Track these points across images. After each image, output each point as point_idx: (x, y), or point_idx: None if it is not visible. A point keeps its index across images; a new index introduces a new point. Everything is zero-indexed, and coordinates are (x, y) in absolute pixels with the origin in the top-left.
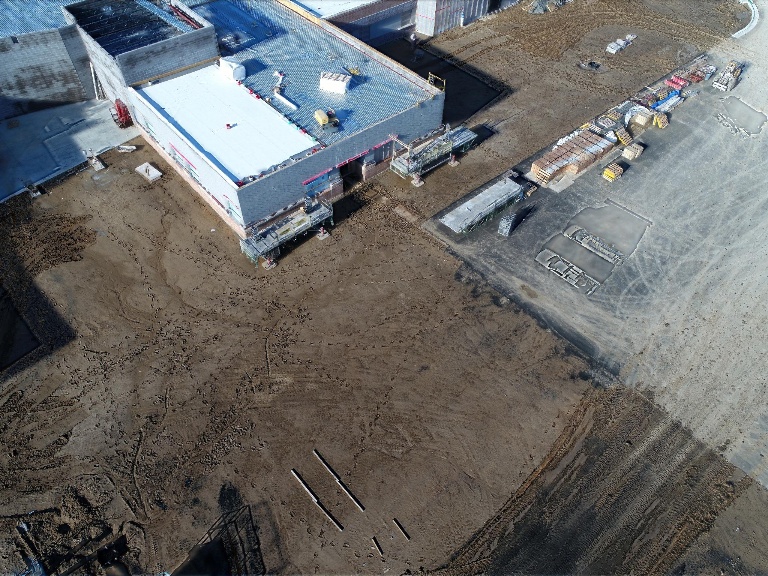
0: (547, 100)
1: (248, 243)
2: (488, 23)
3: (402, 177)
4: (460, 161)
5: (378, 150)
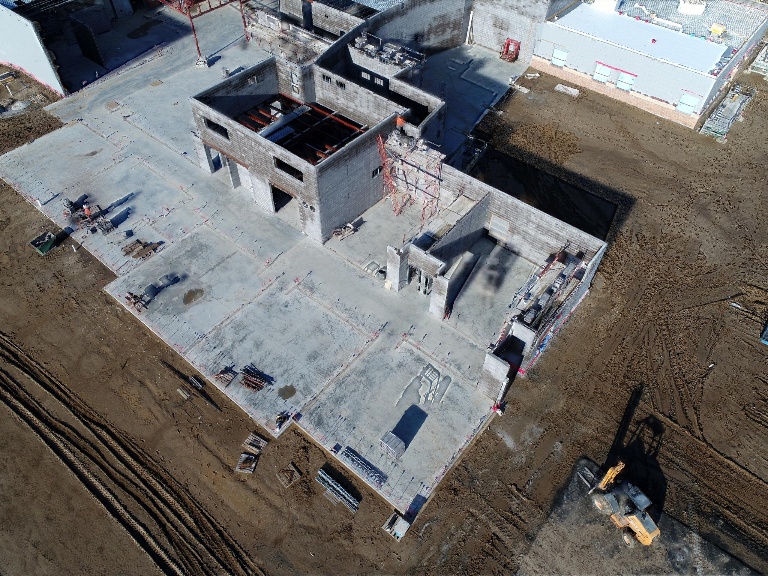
0: None
1: None
2: None
3: (763, 74)
4: None
5: None
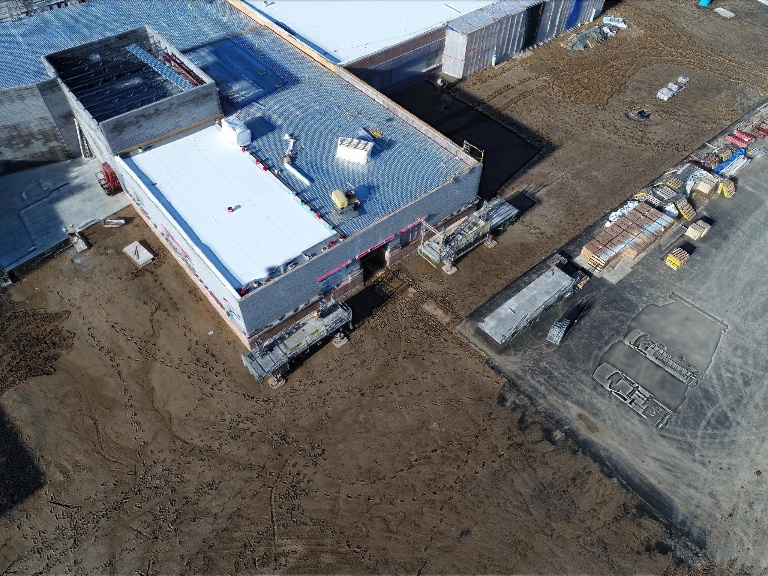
0: (594, 160)
1: (251, 358)
2: (522, 62)
3: (432, 264)
4: (498, 240)
5: (404, 233)
